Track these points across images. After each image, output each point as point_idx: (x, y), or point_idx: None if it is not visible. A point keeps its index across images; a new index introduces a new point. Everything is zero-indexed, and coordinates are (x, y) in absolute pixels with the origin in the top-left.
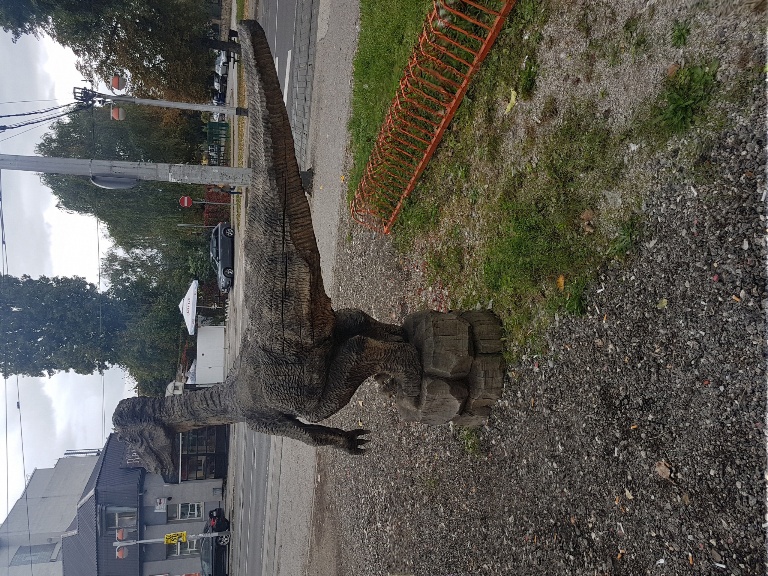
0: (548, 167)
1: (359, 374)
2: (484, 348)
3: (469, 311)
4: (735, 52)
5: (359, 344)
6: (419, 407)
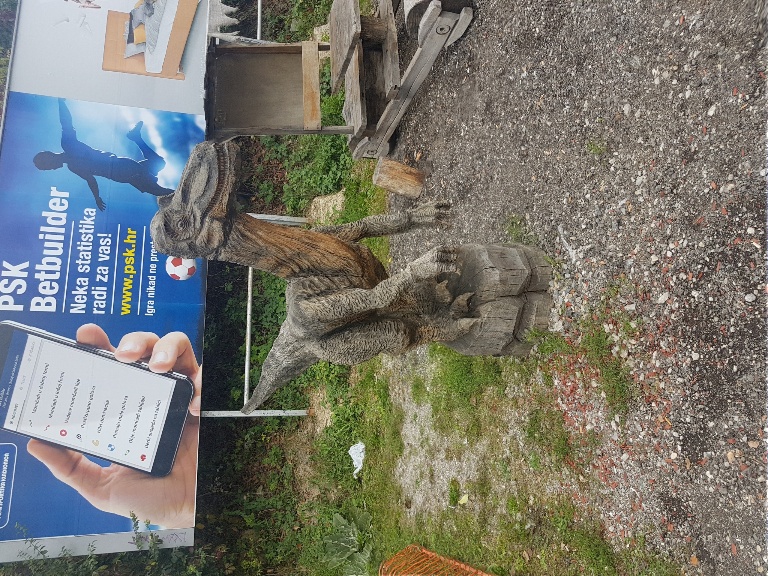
0: None
1: None
2: None
3: None
4: None
5: None
6: None
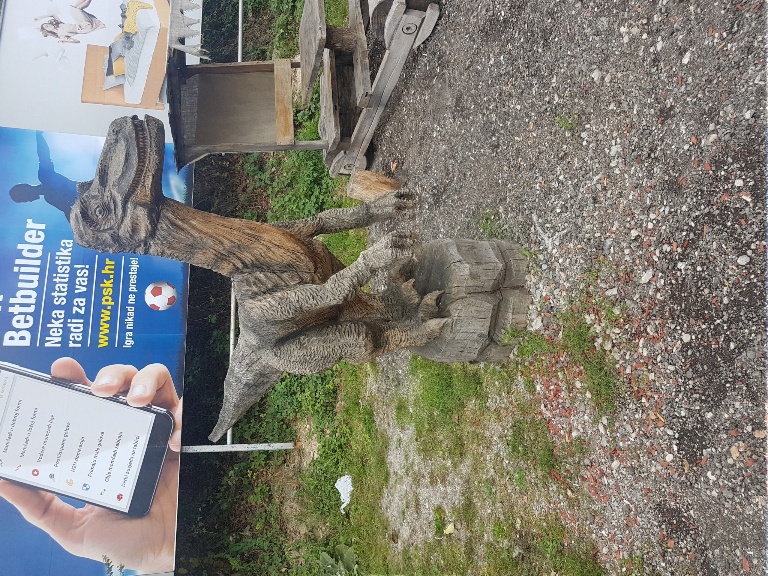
0: None
1: None
2: None
3: None
4: (393, 416)
5: None
6: None
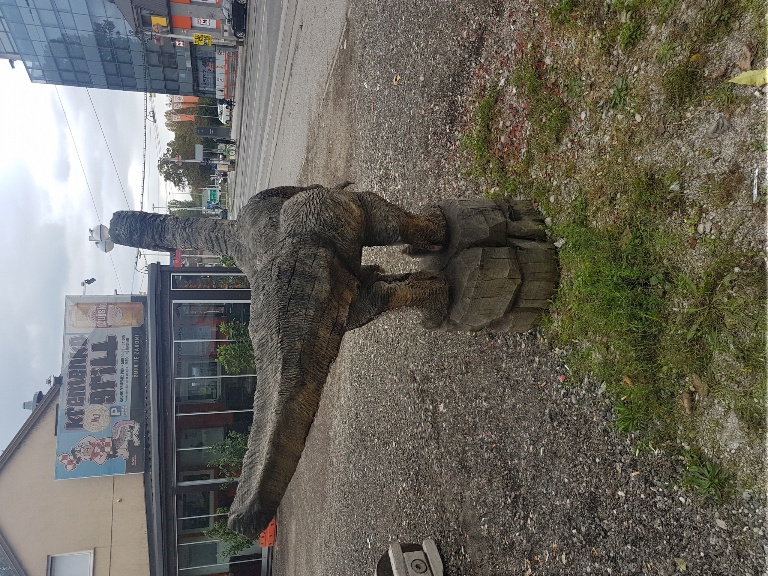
0: (706, 286)
1: (377, 313)
2: (525, 305)
3: (530, 251)
4: None
5: (383, 300)
6: (434, 328)
